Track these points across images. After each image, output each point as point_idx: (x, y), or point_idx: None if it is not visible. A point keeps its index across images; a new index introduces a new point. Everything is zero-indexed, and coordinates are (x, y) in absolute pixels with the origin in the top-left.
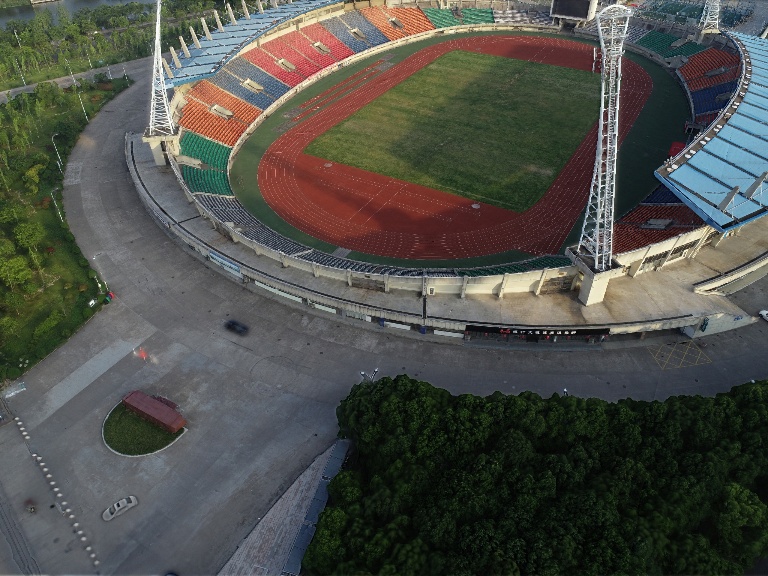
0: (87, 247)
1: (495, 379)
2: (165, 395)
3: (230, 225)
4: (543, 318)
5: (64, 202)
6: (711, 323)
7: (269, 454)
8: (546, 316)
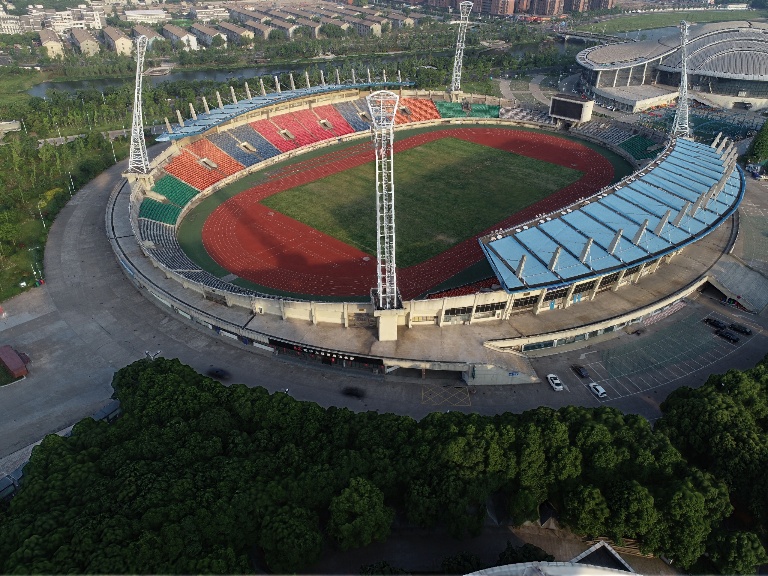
0: (51, 248)
1: (276, 386)
2: (28, 353)
3: (150, 244)
4: (336, 344)
5: (58, 216)
6: (483, 373)
7: (68, 404)
8: (340, 343)
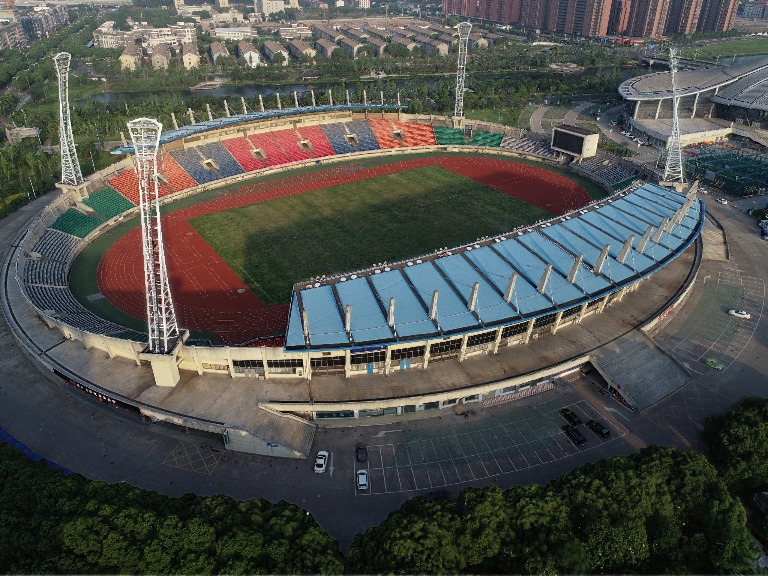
0: None
1: (39, 419)
2: None
3: (38, 255)
4: (112, 383)
5: (3, 219)
6: (239, 439)
7: None
8: (117, 382)
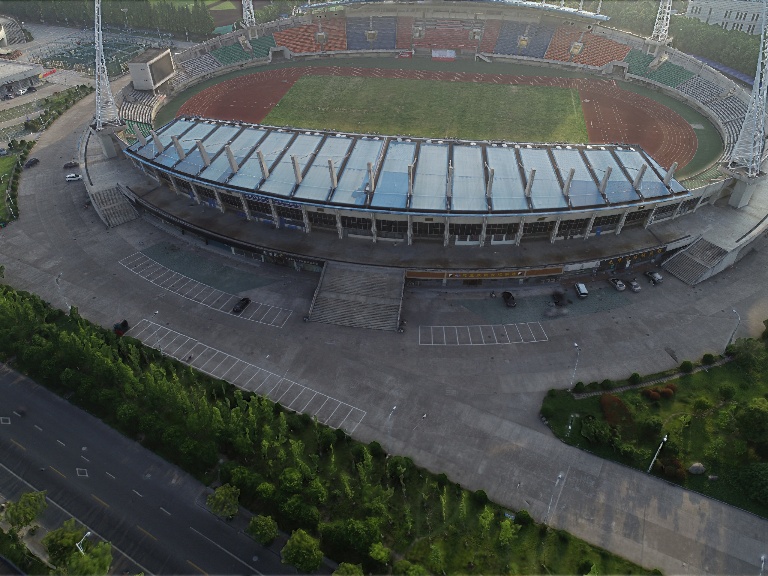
0: None
1: None
2: None
3: None
4: None
5: None
6: None
7: None
8: None
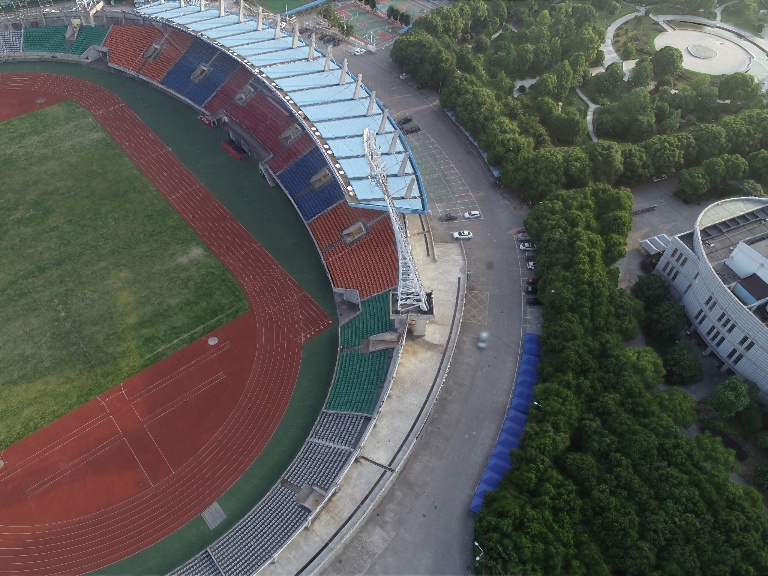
0: None
1: (461, 443)
2: None
3: None
4: (427, 373)
5: None
6: None
7: None
8: (426, 370)
